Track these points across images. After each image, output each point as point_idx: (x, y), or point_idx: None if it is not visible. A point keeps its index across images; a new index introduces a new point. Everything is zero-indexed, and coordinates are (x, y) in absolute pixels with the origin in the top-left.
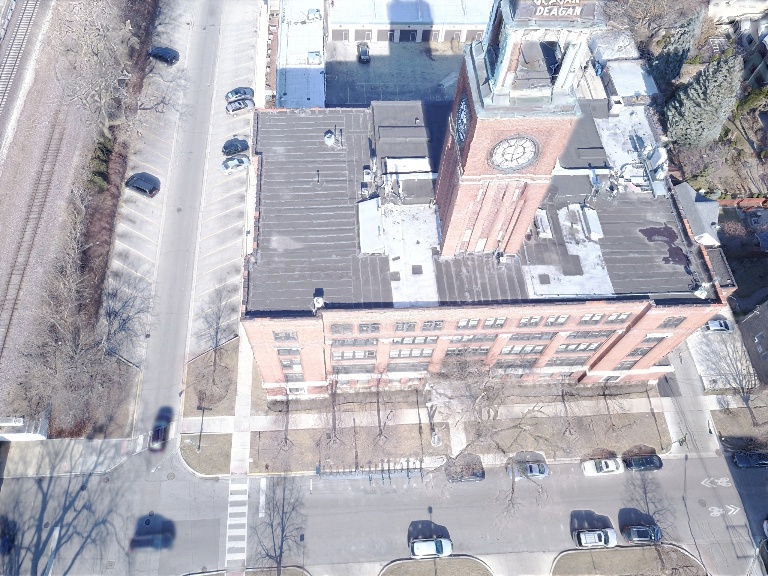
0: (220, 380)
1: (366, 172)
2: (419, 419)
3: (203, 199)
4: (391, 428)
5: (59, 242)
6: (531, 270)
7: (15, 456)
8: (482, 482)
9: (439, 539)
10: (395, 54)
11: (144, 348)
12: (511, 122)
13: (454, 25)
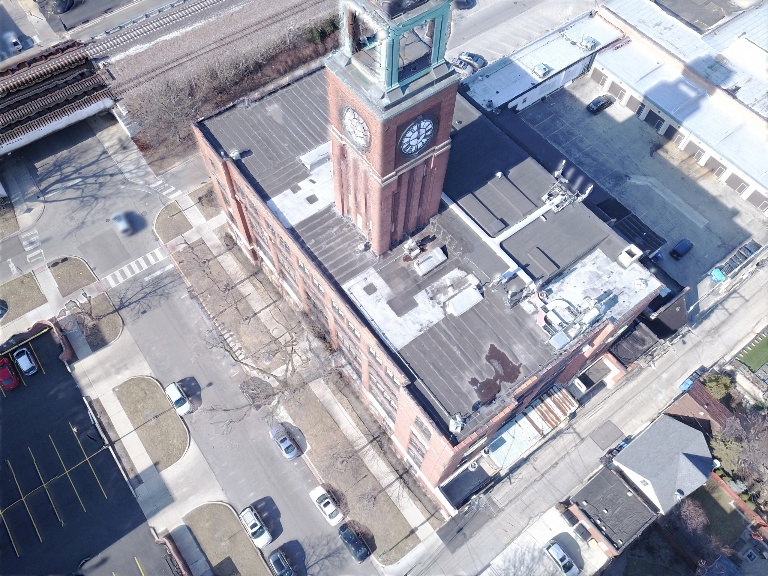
0: None
1: None
2: (279, 337)
3: None
4: (259, 322)
5: (256, 48)
6: (372, 275)
7: (112, 131)
8: (254, 411)
9: (187, 400)
10: (626, 126)
11: None
12: None
13: (701, 141)
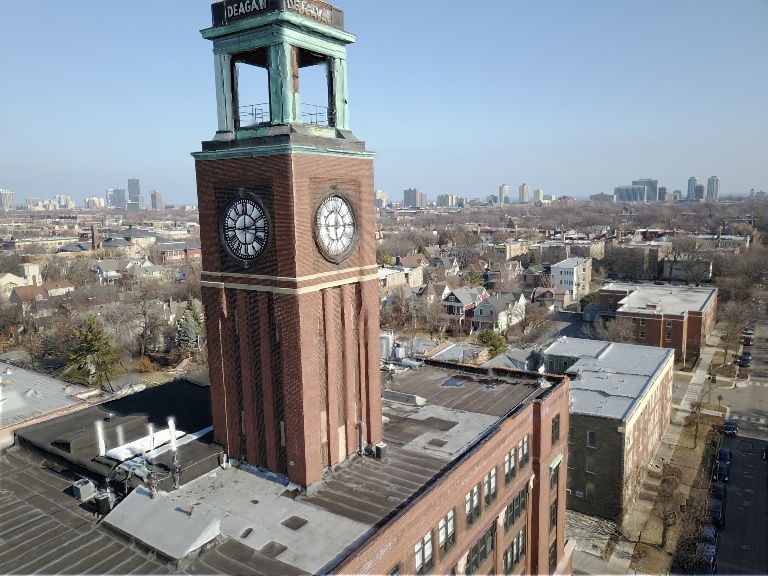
0: None
1: (80, 483)
2: None
3: None
4: None
5: None
6: (415, 445)
7: None
8: None
9: None
10: None
11: None
12: (321, 170)
13: None
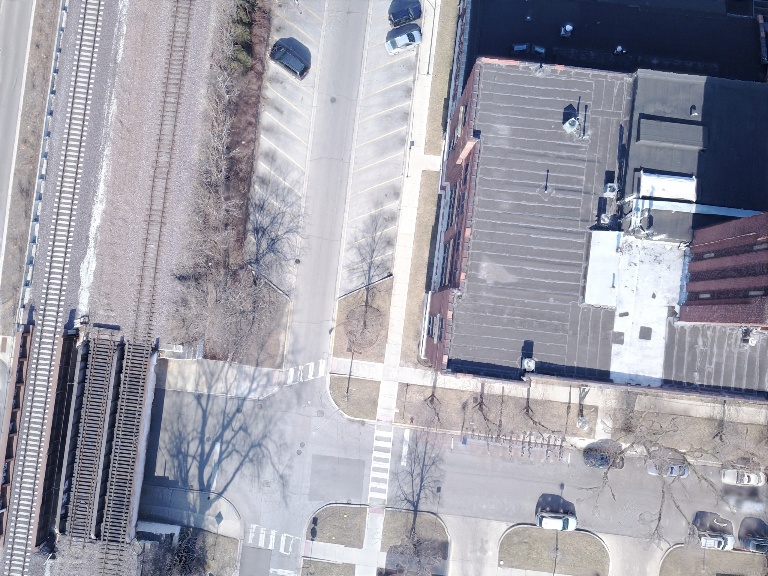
0: (371, 324)
1: (611, 187)
2: (569, 398)
3: (361, 88)
4: (539, 403)
5: (201, 139)
6: None
7: (174, 370)
8: (618, 470)
9: (567, 517)
10: None
11: (294, 275)
12: None
13: None
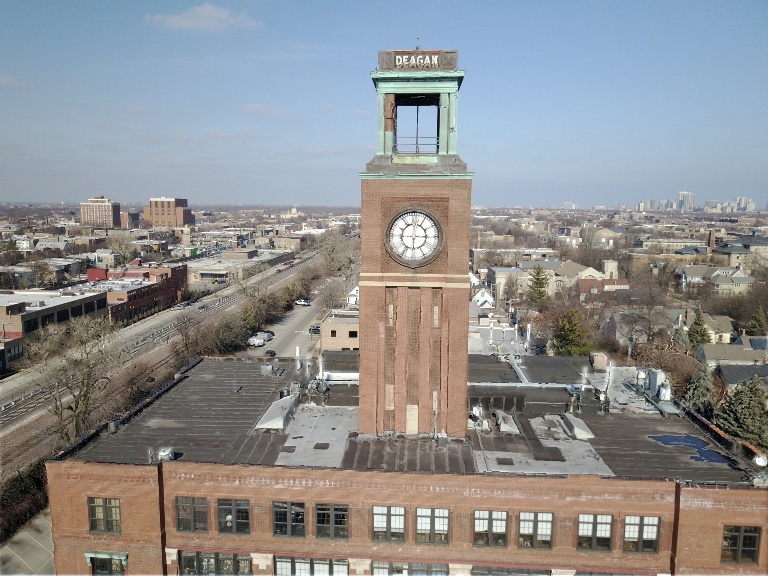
0: None
1: (294, 383)
2: None
3: None
4: None
5: None
6: (486, 453)
7: None
8: None
9: None
10: None
11: None
12: (400, 191)
13: None
